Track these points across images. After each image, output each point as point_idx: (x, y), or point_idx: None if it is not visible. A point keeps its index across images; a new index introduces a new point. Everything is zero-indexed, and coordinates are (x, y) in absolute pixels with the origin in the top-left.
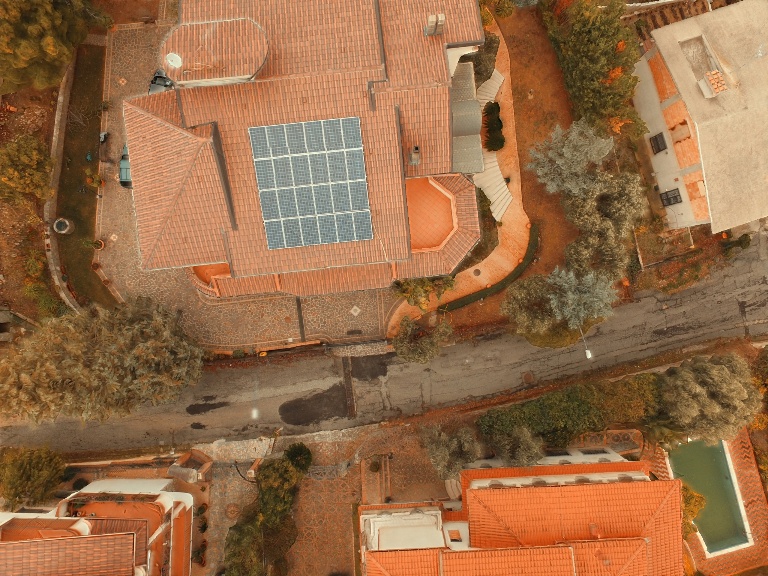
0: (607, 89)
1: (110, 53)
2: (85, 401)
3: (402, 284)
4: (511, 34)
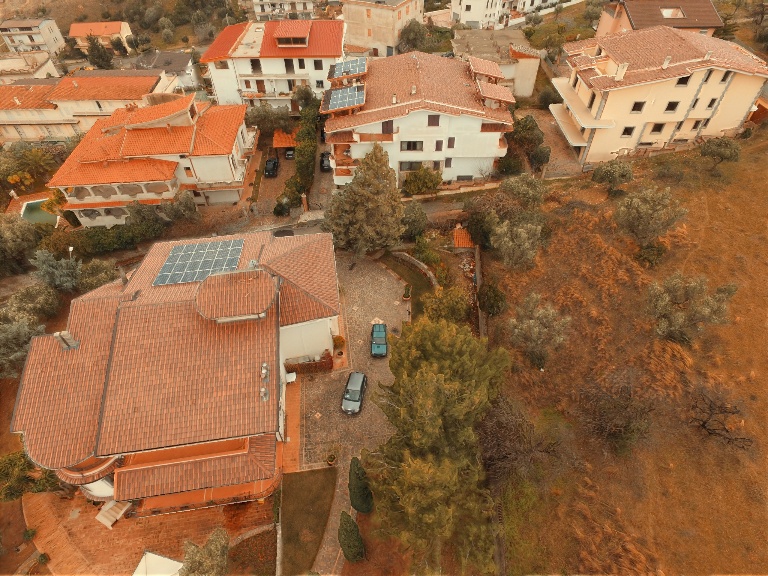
0: None
1: None
2: None
3: None
4: None
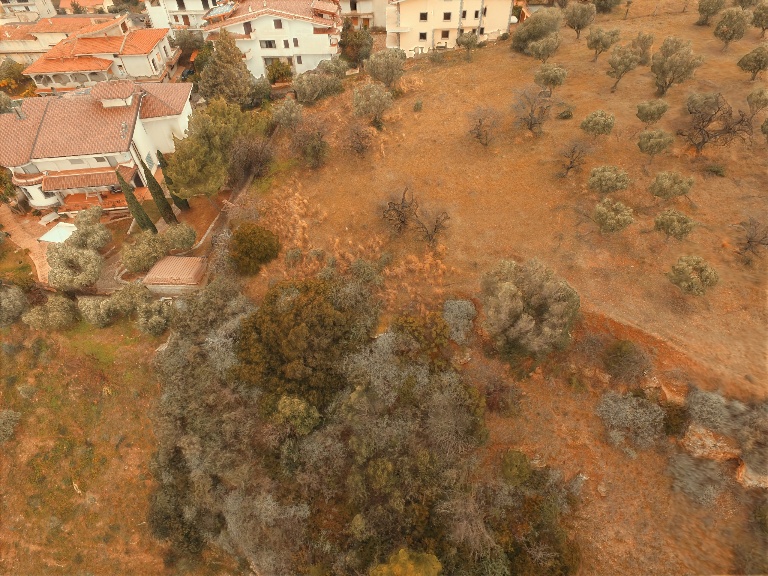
0: None
1: None
2: None
3: None
4: None
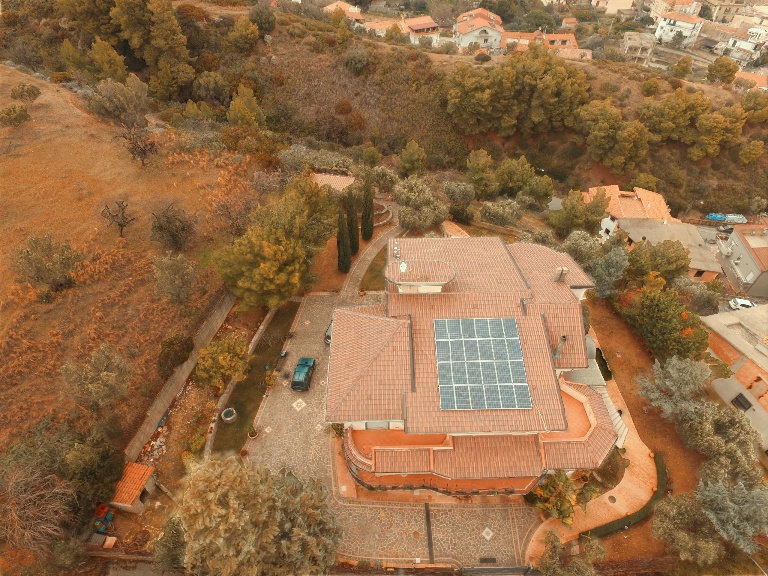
0: (686, 339)
1: (303, 306)
2: (247, 536)
3: (540, 498)
4: (591, 317)
